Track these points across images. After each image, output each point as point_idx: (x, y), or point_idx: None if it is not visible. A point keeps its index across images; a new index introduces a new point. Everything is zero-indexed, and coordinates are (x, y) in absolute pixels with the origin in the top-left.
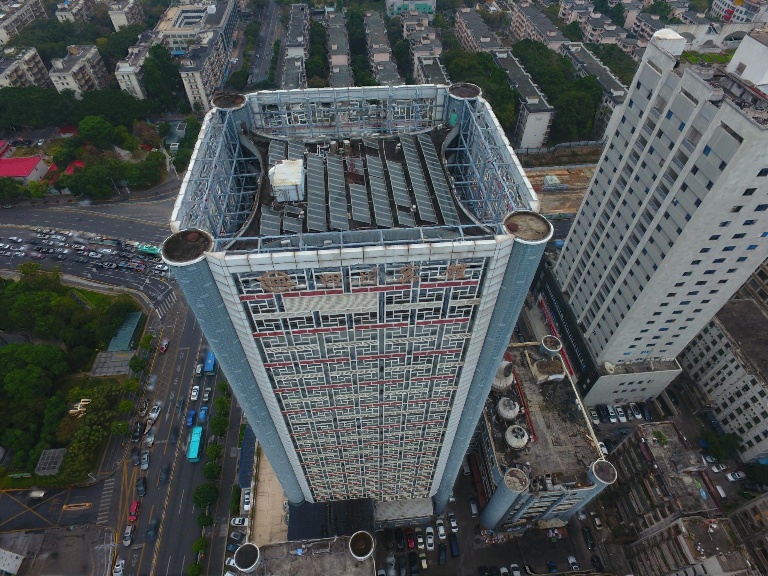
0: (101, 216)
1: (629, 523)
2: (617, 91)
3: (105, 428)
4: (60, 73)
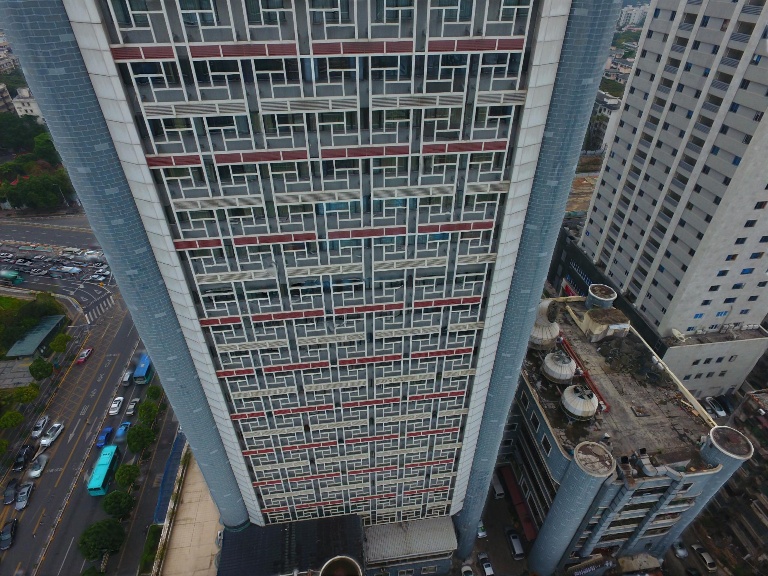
0: (42, 227)
1: (757, 557)
2: (611, 99)
3: None
4: (24, 99)
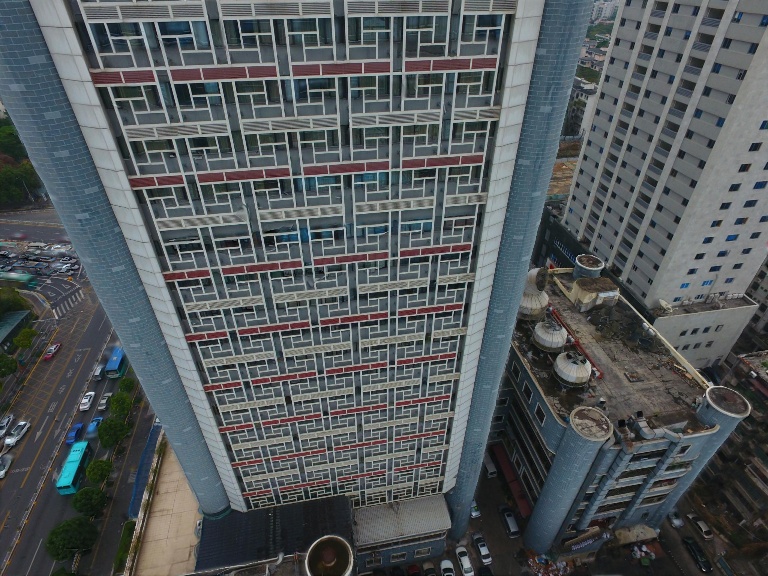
0: (5, 223)
1: (752, 522)
2: (587, 84)
3: None
4: None
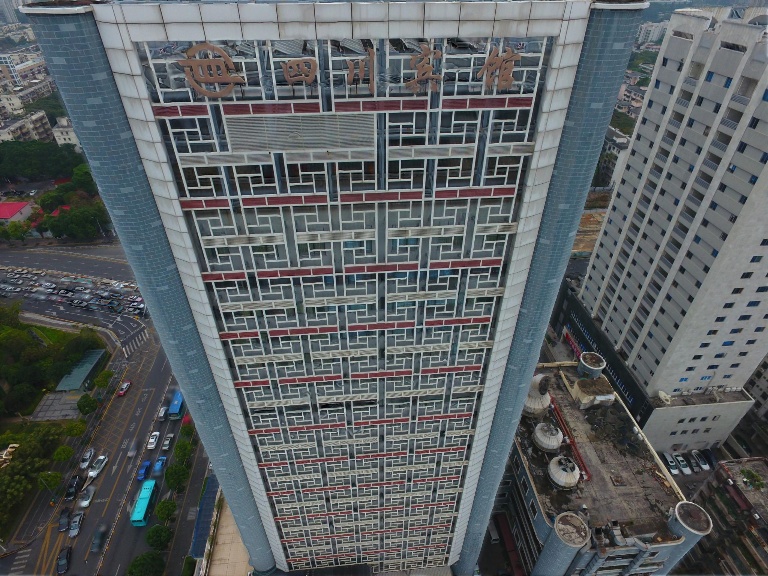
0: (80, 257)
1: None
2: (620, 138)
3: (33, 482)
4: (63, 129)
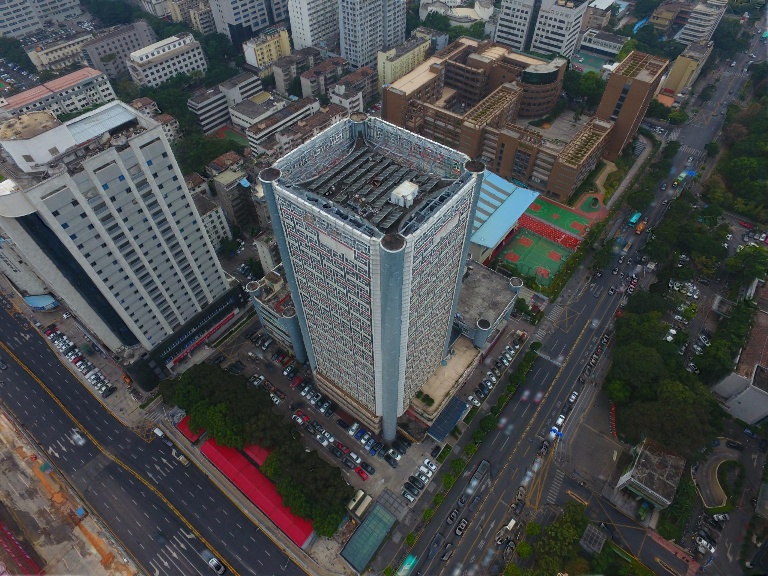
0: None
1: None
2: None
3: None
4: None
